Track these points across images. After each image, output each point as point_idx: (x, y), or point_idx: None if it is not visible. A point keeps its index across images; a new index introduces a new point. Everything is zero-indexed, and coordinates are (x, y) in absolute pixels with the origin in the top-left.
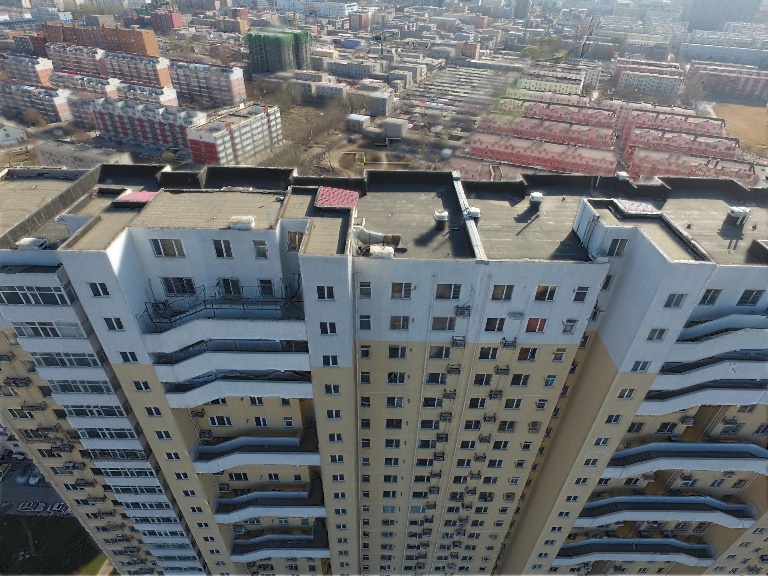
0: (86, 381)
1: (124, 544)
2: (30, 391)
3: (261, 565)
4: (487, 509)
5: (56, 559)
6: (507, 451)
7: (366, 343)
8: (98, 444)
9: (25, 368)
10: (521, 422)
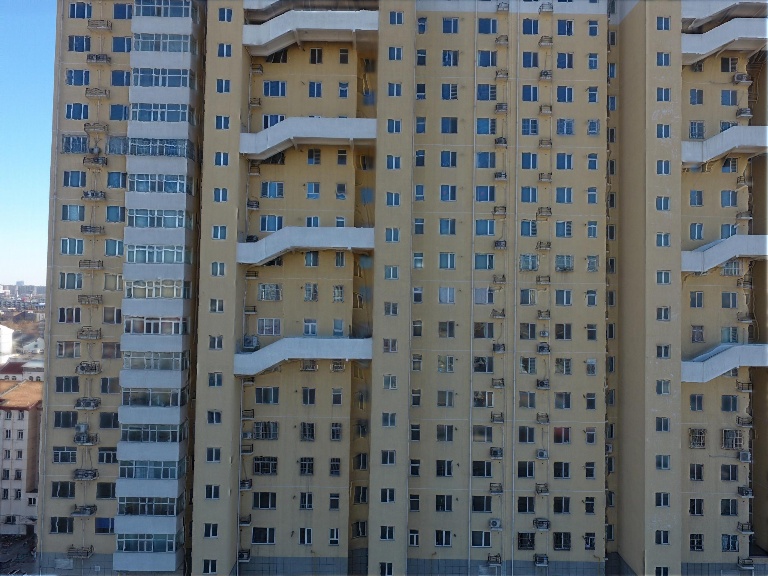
0: (170, 34)
1: (80, 392)
2: (102, 76)
3: (260, 460)
4: (570, 297)
5: None
6: (573, 170)
7: (423, 14)
8: (144, 129)
9: (112, 48)
10: (578, 119)
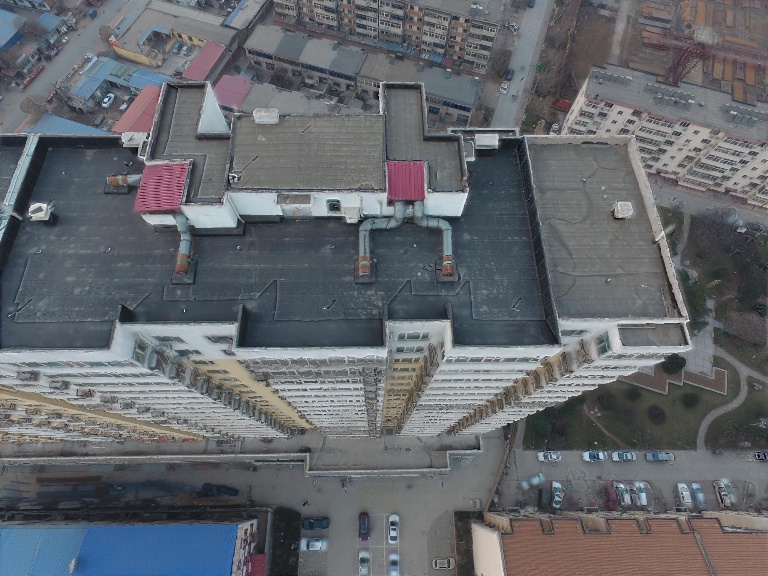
0: None
1: None
2: None
3: None
4: None
5: (566, 409)
6: None
7: None
8: None
9: None
10: None
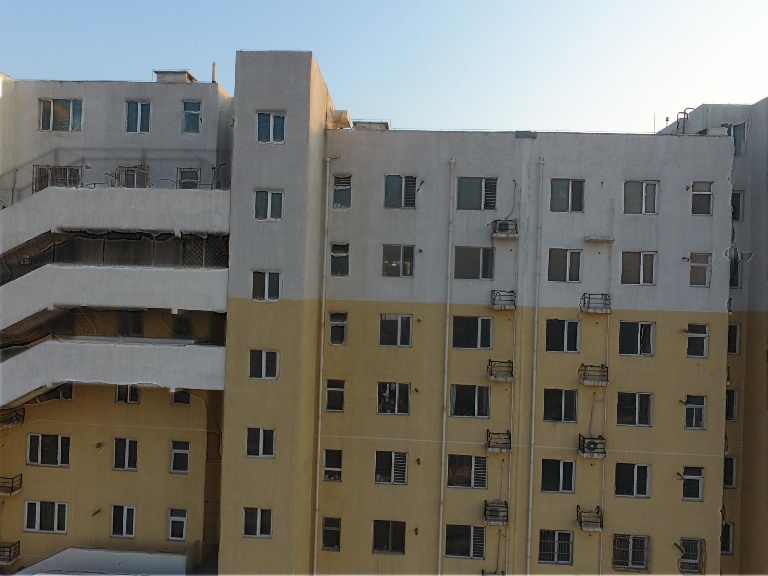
0: None
1: None
2: None
3: None
4: None
5: None
6: None
7: (340, 306)
8: None
9: None
10: (659, 537)
